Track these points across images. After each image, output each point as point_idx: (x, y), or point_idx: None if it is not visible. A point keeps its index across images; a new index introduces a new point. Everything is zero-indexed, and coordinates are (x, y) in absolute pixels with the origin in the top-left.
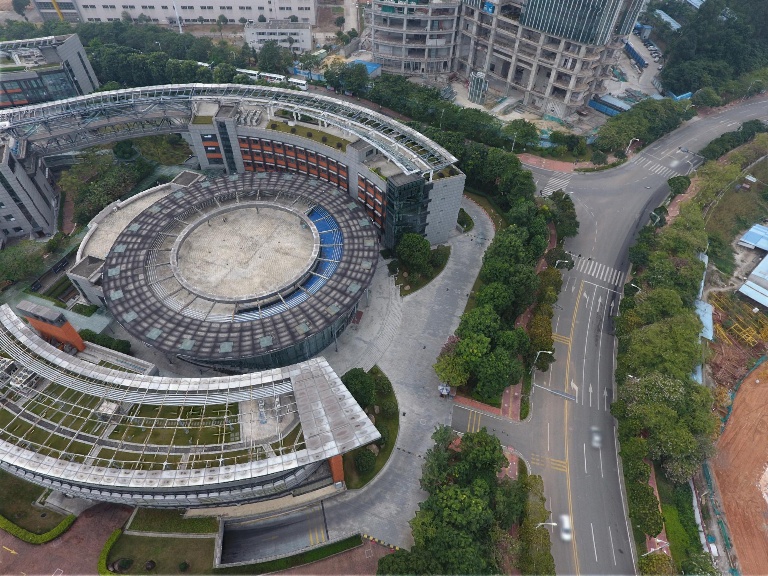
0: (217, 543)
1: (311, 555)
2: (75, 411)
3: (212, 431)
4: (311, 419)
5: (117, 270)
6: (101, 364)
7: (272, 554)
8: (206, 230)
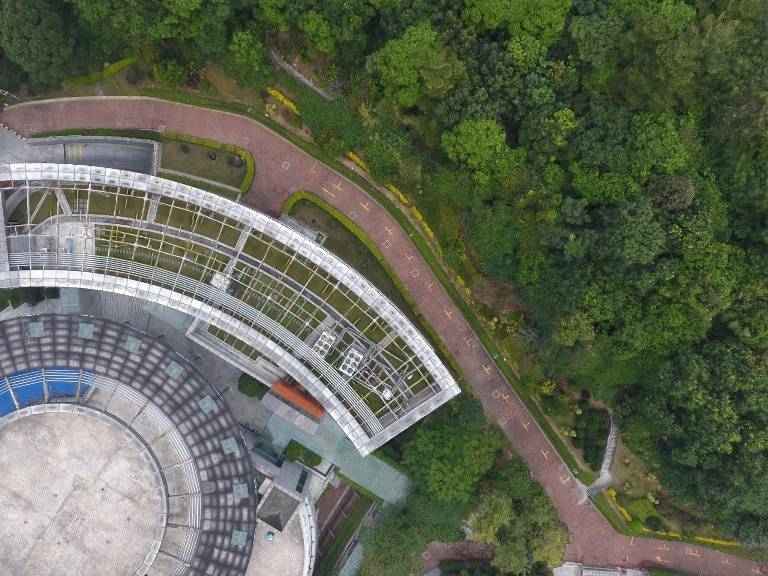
0: (158, 162)
1: (75, 133)
2: None
3: None
4: None
5: (237, 494)
6: (255, 355)
7: (120, 150)
8: (135, 571)
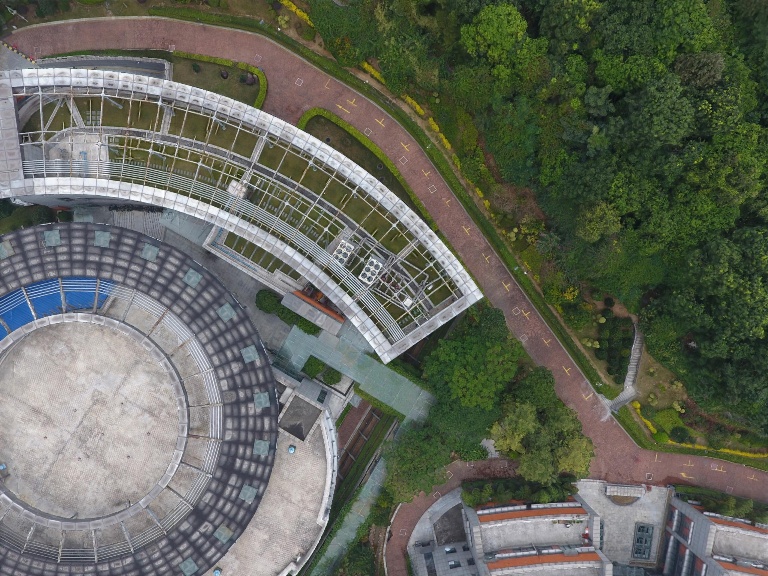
0: None
1: (85, 54)
2: (287, 209)
3: (138, 154)
4: (4, 120)
5: (259, 404)
6: (272, 268)
7: None
8: None
